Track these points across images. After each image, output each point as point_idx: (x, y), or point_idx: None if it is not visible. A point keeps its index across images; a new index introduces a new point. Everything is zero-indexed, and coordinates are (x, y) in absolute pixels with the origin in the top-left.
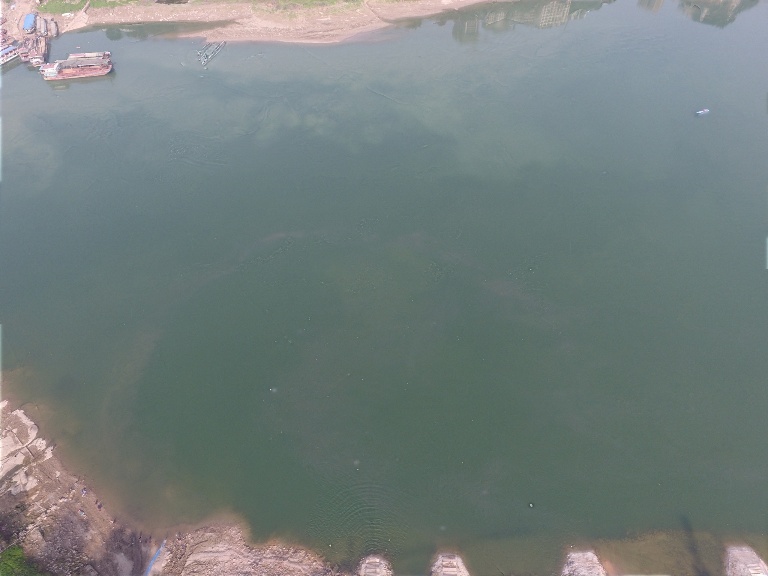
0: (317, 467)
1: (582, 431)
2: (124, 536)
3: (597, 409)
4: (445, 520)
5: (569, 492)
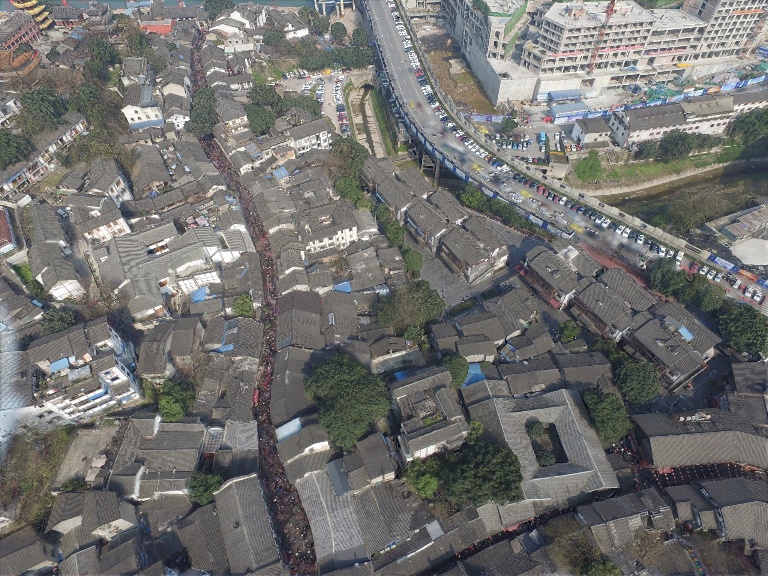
0: None
1: None
2: None
3: None
4: None
5: (125, 5)
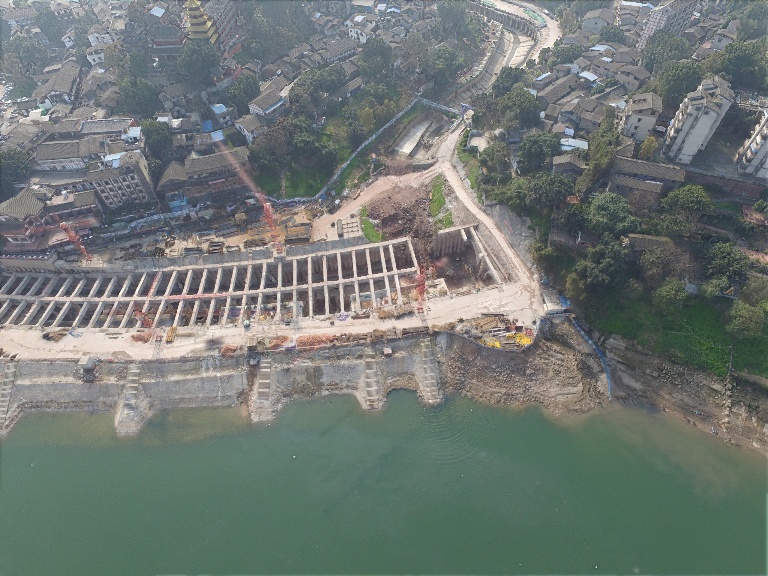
0: (504, 473)
1: (216, 541)
2: (647, 401)
3: (185, 573)
4: (375, 437)
5: (255, 471)
